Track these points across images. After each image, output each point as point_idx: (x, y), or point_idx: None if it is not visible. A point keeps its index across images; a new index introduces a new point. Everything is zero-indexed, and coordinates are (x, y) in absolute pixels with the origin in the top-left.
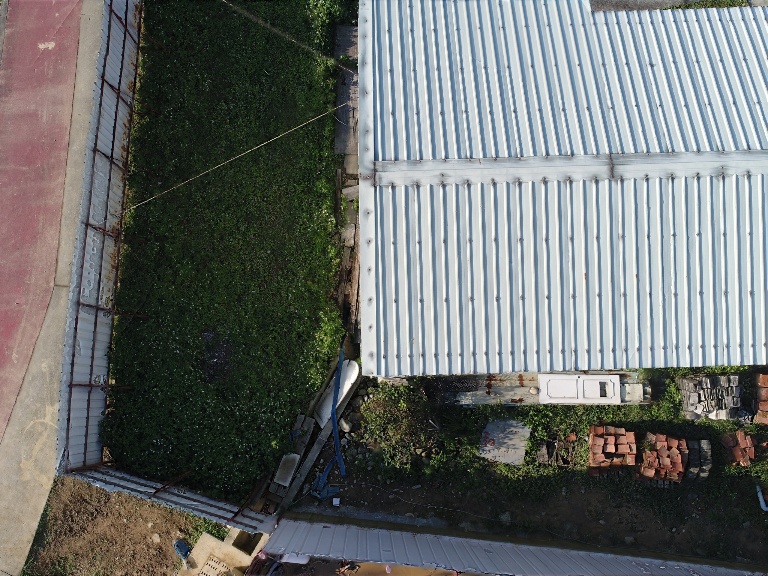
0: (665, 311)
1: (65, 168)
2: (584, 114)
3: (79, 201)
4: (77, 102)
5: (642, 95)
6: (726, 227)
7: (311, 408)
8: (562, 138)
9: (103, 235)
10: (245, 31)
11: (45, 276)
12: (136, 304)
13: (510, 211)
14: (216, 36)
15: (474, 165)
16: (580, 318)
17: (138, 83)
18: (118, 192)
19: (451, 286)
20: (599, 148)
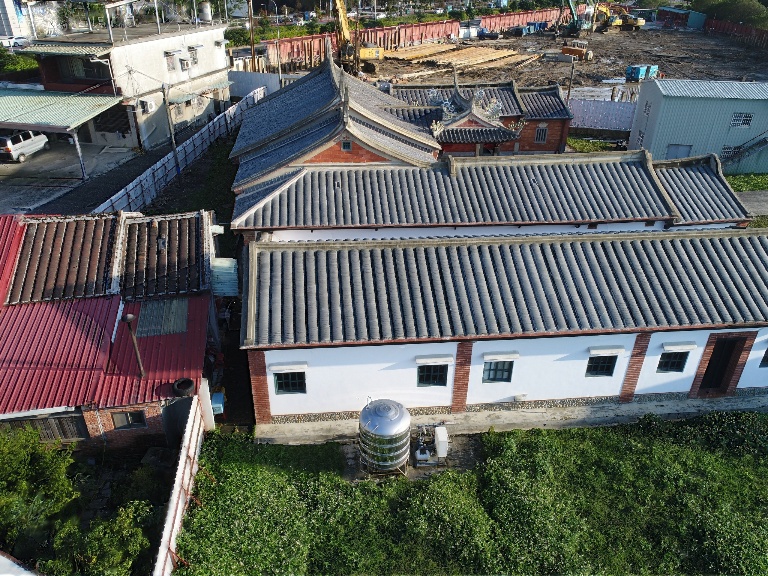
0: None
1: None
2: None
3: None
4: None
5: (759, 89)
6: None
7: None
8: None
9: None
10: None
11: None
12: None
13: None
14: None
15: None
16: None
17: None
18: None
19: None
20: None
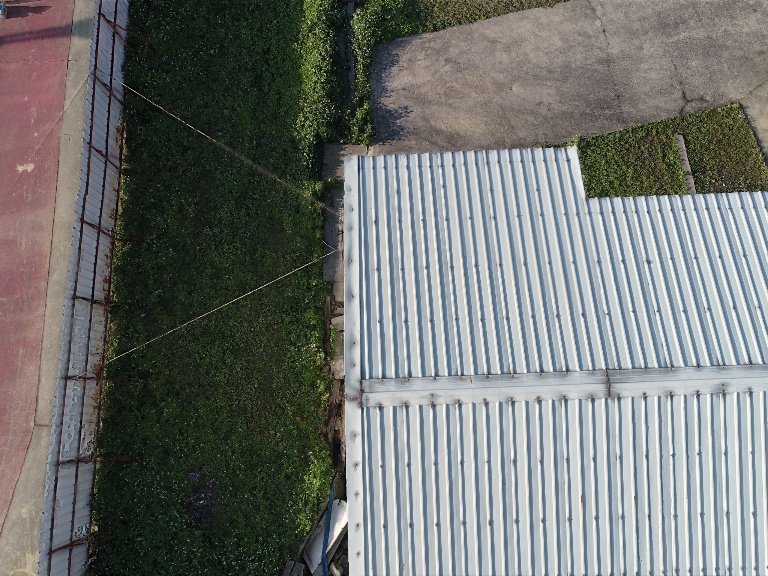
0: (665, 533)
1: (45, 299)
2: (579, 321)
3: (60, 334)
4: (57, 228)
5: (639, 298)
6: (727, 445)
7: (301, 551)
8: (556, 350)
9: (84, 380)
10: (230, 151)
11: (25, 415)
12: (119, 444)
13: (503, 431)
14: (200, 156)
15: (465, 384)
16: (576, 541)
17: (120, 207)
18: (100, 328)
19: (442, 509)
20: (595, 362)
